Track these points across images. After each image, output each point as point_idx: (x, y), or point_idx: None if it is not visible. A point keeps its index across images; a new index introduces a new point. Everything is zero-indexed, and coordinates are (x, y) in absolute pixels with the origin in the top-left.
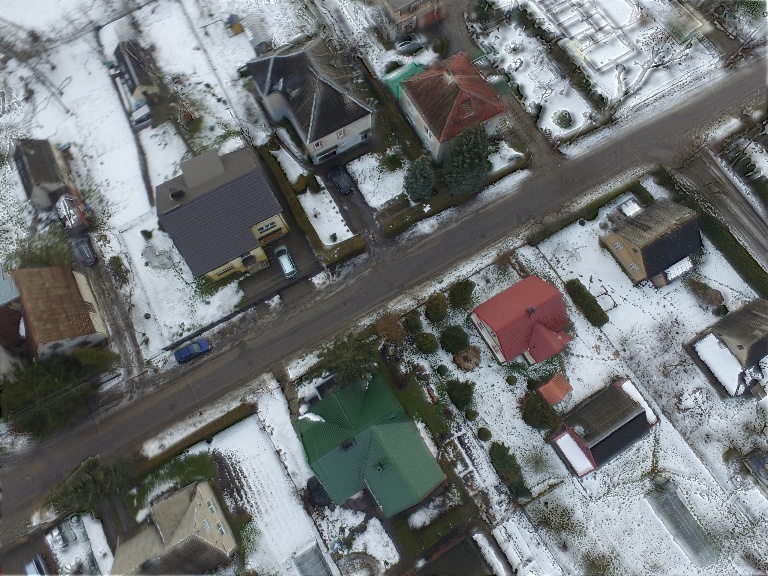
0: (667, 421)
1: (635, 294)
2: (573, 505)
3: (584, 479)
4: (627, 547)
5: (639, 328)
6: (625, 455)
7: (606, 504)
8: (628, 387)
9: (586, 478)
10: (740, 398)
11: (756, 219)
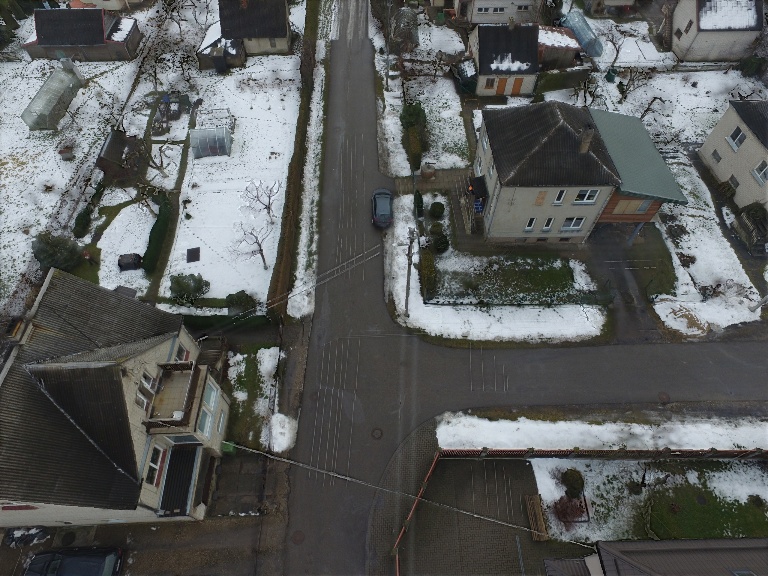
0: (140, 62)
1: (218, 7)
2: (7, 73)
3: (33, 61)
4: (3, 105)
5: (182, 3)
6: (83, 66)
7: (29, 81)
8: (127, 21)
9: (35, 60)
10: (214, 72)
11: (363, 2)
